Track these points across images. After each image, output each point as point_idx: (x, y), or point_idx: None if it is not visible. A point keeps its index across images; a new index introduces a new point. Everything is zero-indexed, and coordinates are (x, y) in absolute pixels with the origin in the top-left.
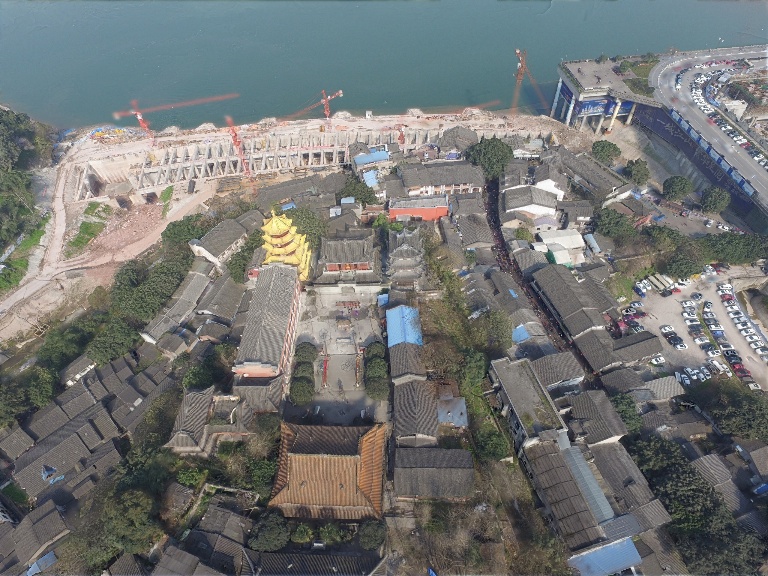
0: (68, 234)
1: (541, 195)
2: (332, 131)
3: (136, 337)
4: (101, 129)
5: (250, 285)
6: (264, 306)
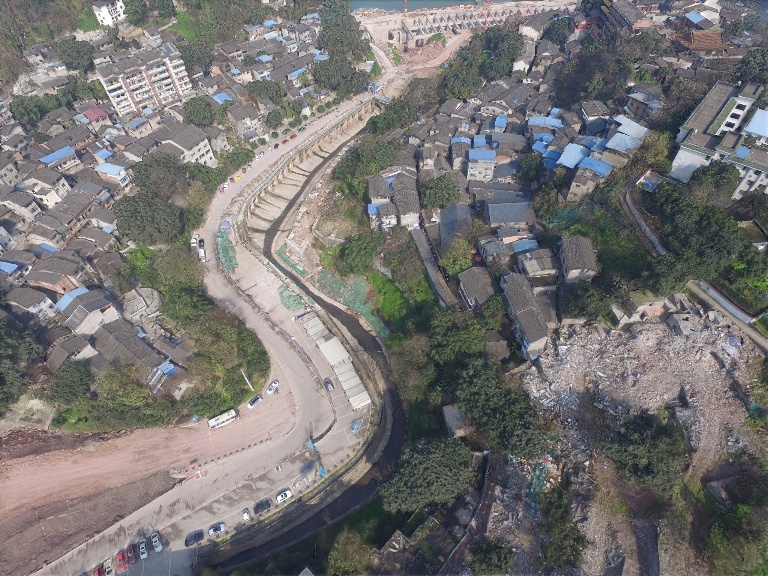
0: (389, 55)
1: (709, 7)
2: (525, 7)
3: (511, 66)
4: (360, 9)
5: (572, 38)
6: (632, 7)
